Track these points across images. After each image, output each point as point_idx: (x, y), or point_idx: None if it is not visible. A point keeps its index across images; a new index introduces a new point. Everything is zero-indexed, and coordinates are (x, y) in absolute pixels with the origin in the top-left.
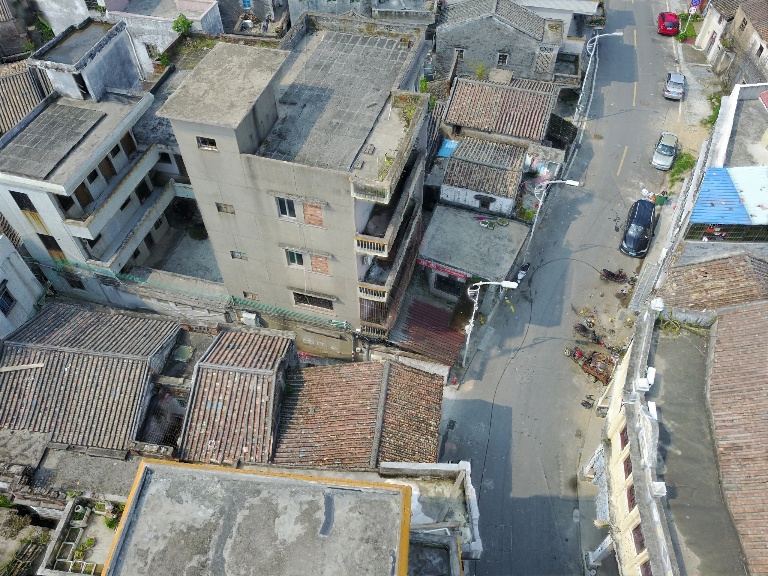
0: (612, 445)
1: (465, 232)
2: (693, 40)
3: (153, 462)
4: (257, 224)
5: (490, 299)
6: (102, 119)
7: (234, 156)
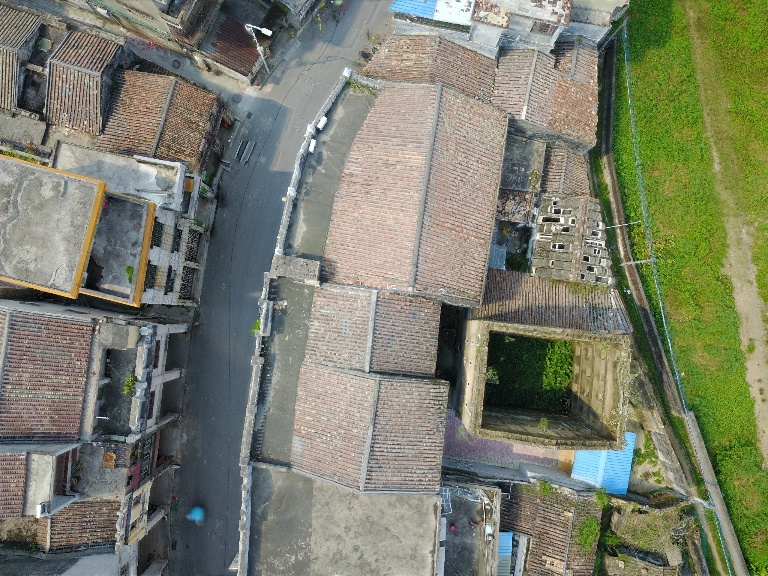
0: None
1: None
2: None
3: None
4: None
5: (295, 19)
6: None
7: None
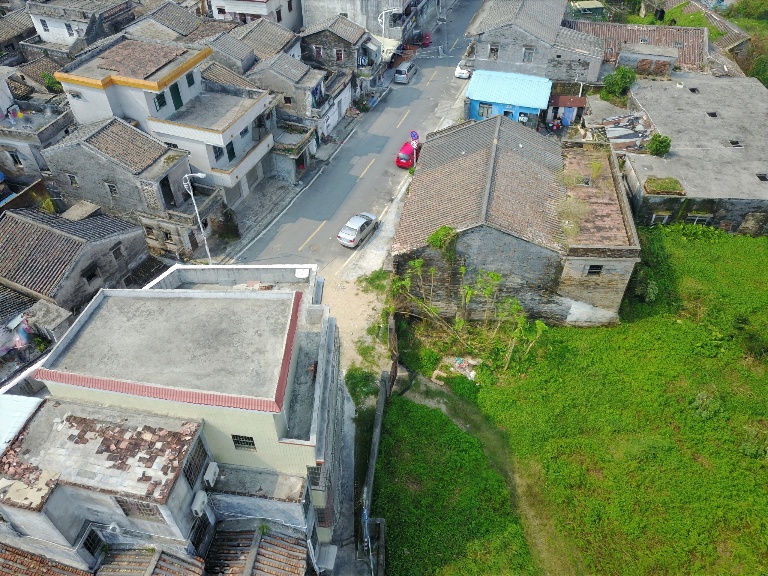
0: None
1: None
2: None
3: None
4: None
5: None
6: None
7: None
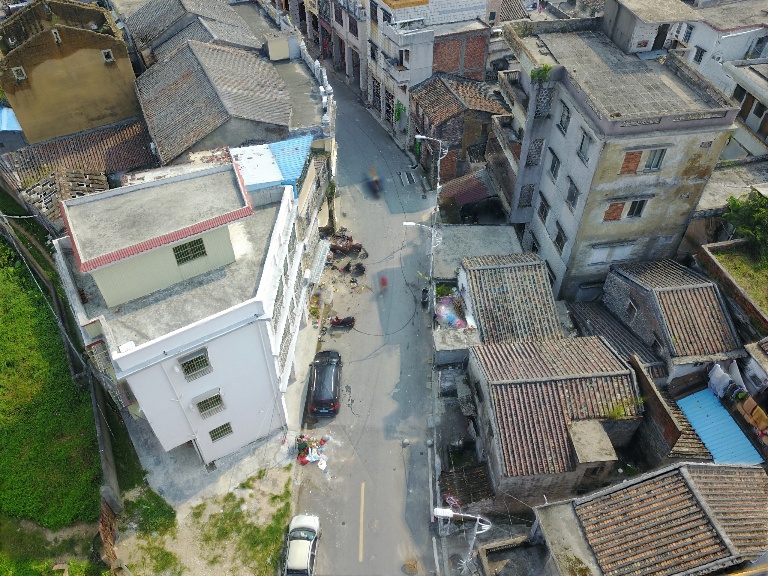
0: None
1: None
2: None
3: None
4: None
5: None
6: None
7: None
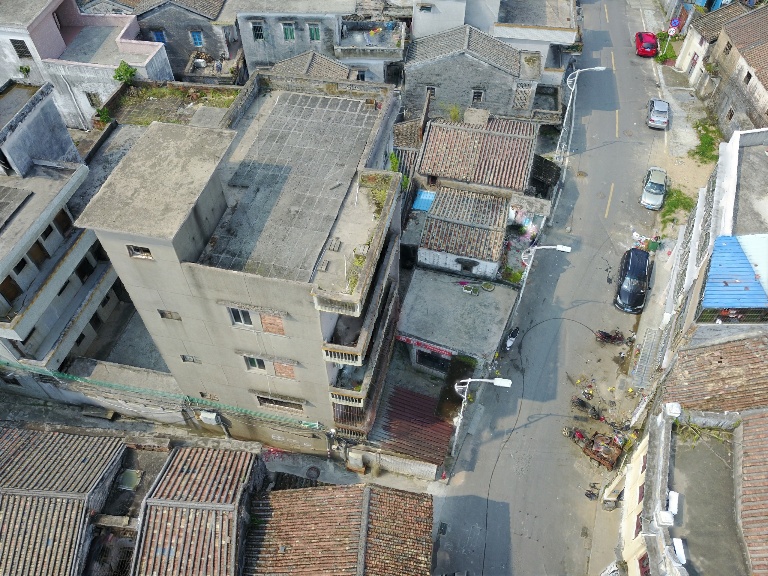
0: (629, 570)
1: (447, 300)
2: (673, 62)
3: None
4: (208, 331)
5: (478, 376)
6: (28, 199)
7: (173, 265)
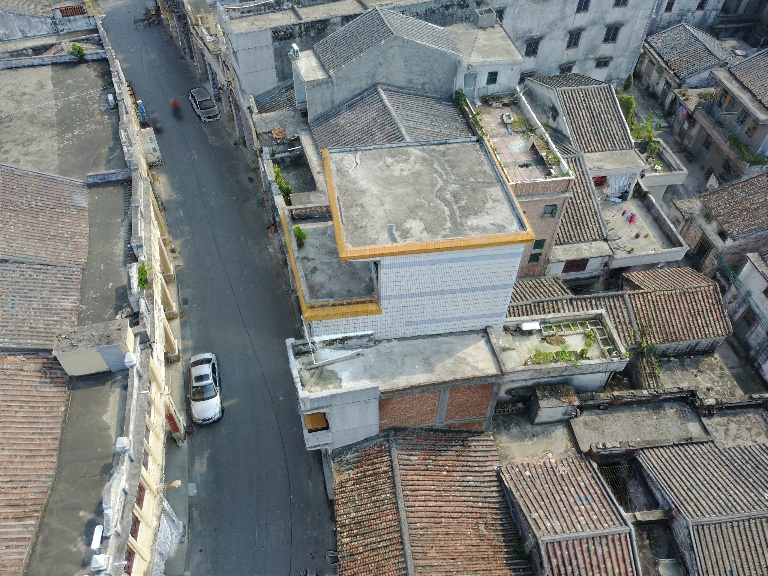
0: None
1: None
2: None
3: (525, 233)
4: None
5: None
6: None
7: None
